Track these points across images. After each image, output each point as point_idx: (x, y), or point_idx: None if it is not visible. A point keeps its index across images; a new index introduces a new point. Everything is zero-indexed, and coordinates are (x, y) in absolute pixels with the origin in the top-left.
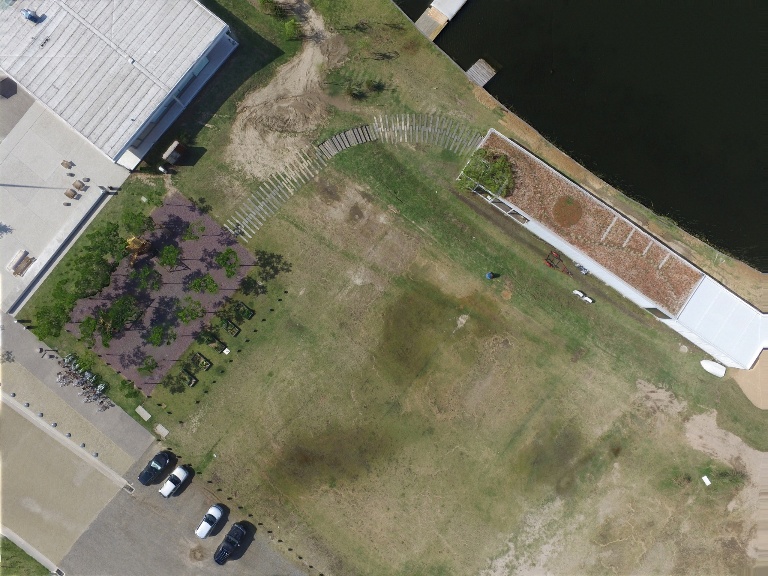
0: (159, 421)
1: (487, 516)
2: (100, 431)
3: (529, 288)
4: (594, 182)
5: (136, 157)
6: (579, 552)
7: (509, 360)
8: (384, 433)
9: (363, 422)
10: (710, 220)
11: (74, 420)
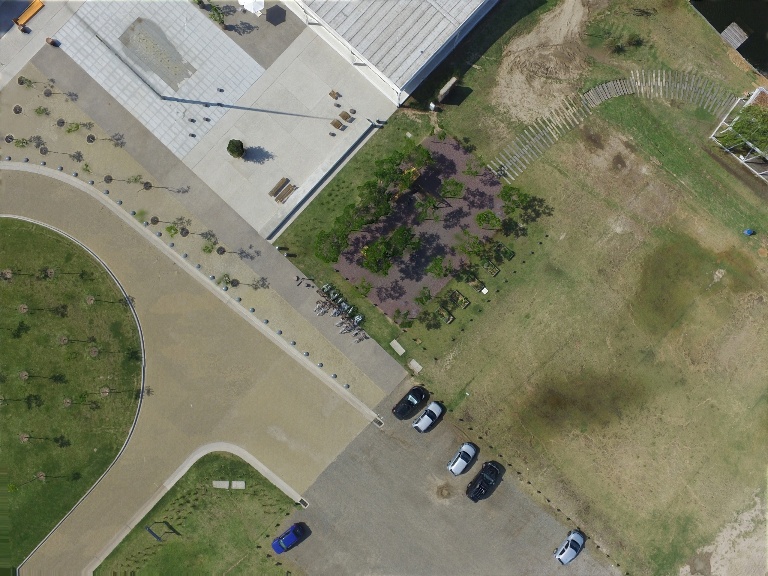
0: (413, 356)
1: (735, 470)
2: (353, 363)
3: None
4: None
5: (405, 92)
6: None
7: (763, 317)
8: (637, 381)
9: (617, 369)
10: None
11: (326, 350)
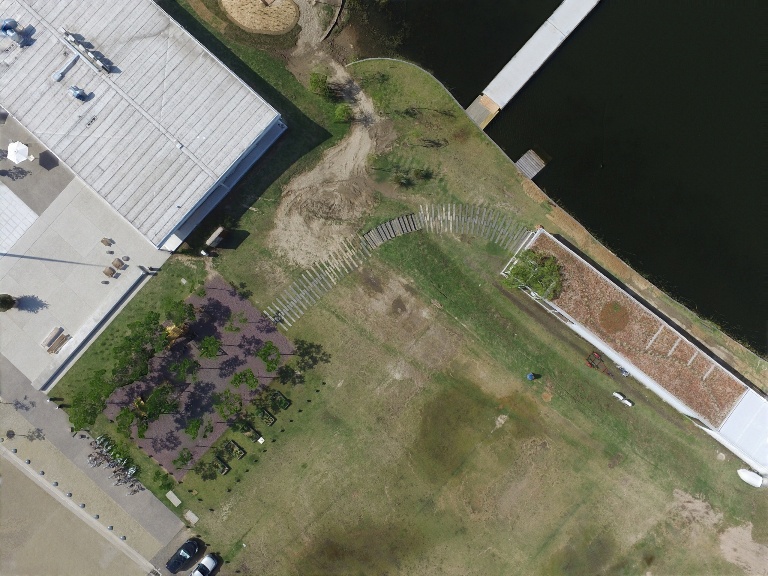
0: (189, 507)
1: None
2: (129, 514)
3: (569, 390)
4: (639, 282)
5: (178, 238)
6: None
7: (546, 463)
8: (416, 531)
9: (396, 519)
10: (754, 326)
11: (103, 502)
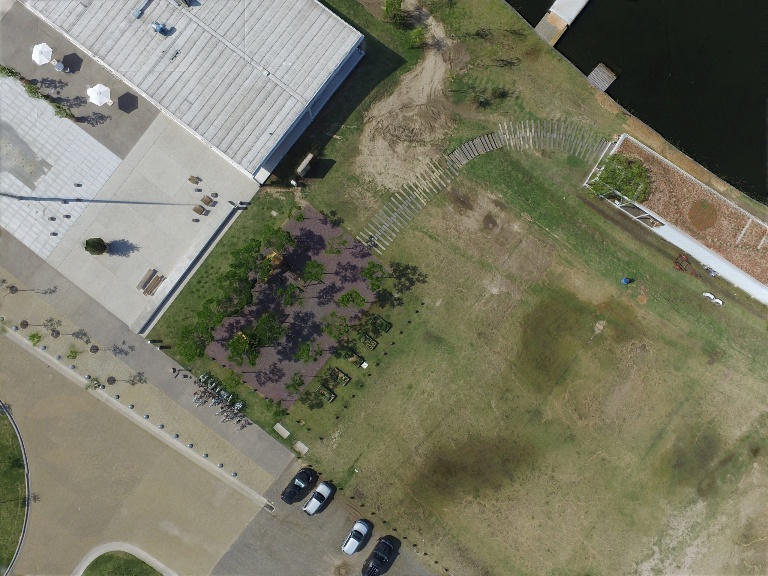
0: (298, 438)
1: (631, 521)
2: (238, 450)
3: (662, 292)
4: (718, 184)
5: (265, 171)
6: (722, 553)
7: (647, 364)
8: (526, 442)
9: (505, 432)
10: None
11: (210, 440)
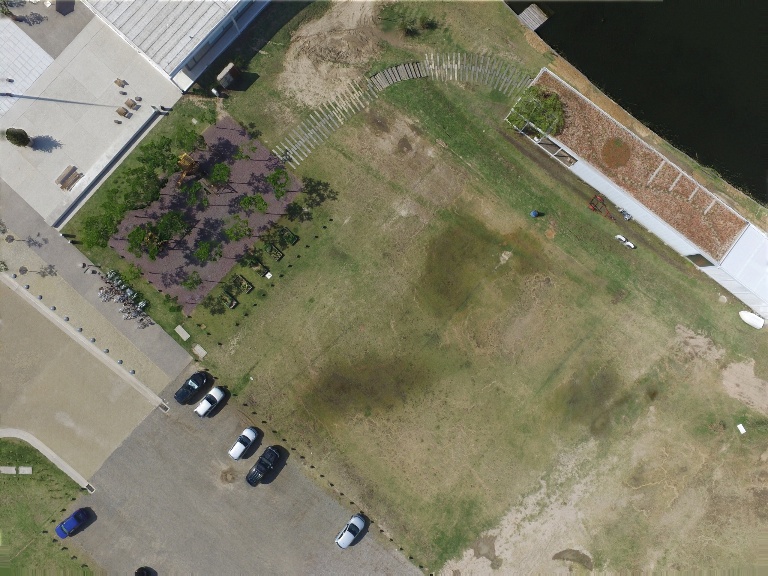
0: (198, 341)
1: (521, 453)
2: (138, 349)
3: (572, 229)
4: (641, 130)
5: (189, 79)
6: (611, 493)
7: (550, 299)
8: (422, 365)
9: (401, 353)
10: (754, 174)
11: (113, 336)
